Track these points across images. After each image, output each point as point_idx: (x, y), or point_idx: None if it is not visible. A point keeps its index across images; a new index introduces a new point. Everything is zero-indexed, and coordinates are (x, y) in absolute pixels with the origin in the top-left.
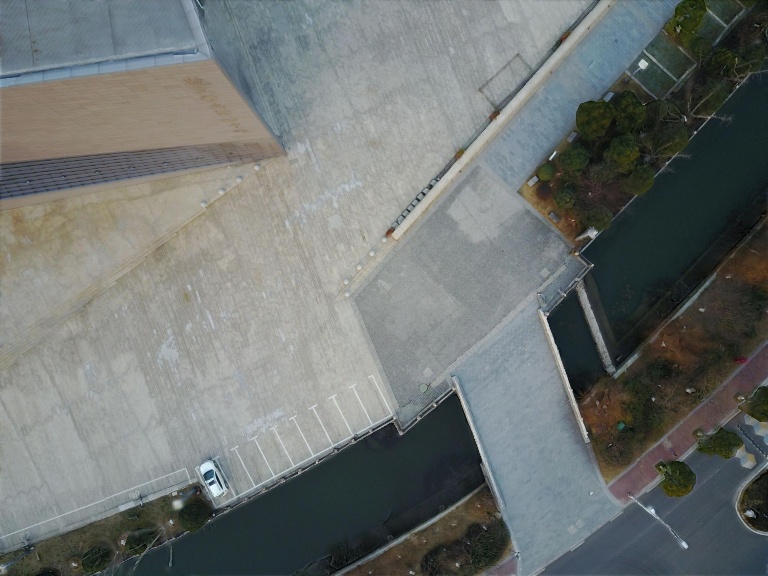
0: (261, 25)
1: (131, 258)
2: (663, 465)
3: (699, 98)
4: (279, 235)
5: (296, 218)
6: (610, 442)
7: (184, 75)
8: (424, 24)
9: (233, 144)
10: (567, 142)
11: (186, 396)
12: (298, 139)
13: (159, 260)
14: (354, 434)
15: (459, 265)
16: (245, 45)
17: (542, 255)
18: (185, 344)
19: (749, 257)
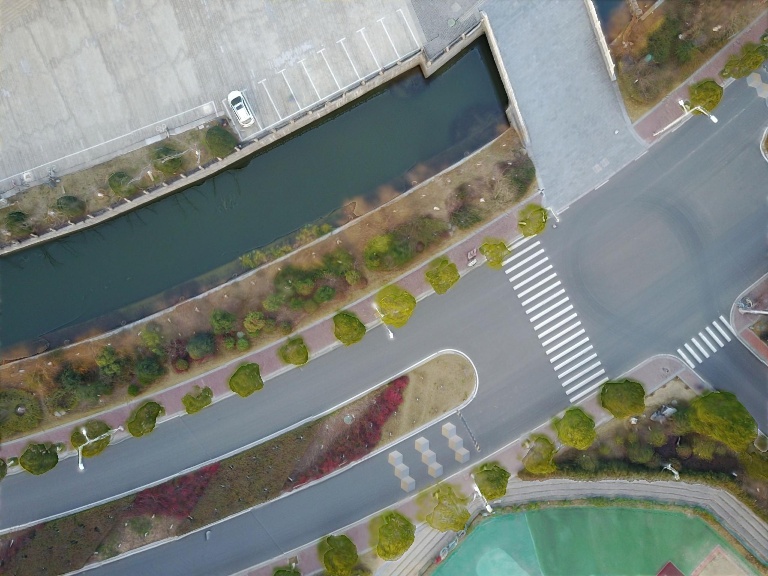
0: None
1: None
2: (688, 104)
3: None
4: None
5: None
6: (636, 77)
7: None
8: None
9: None
10: None
11: (215, 28)
12: None
13: None
14: (381, 68)
15: None
16: None
17: None
18: None
19: None
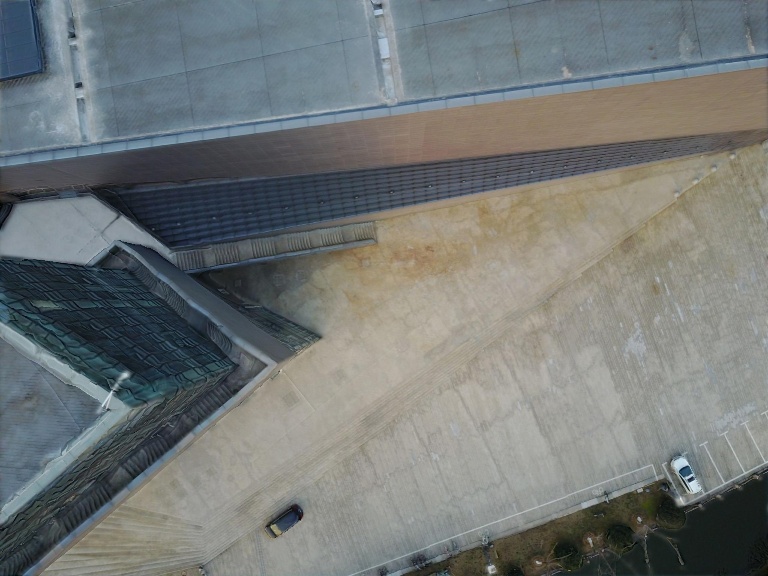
0: None
1: (600, 250)
2: None
3: None
4: (753, 226)
5: None
6: None
7: None
8: None
9: (753, 131)
10: None
11: (653, 391)
12: None
13: (626, 252)
14: None
15: None
16: None
17: None
18: (653, 337)
19: None
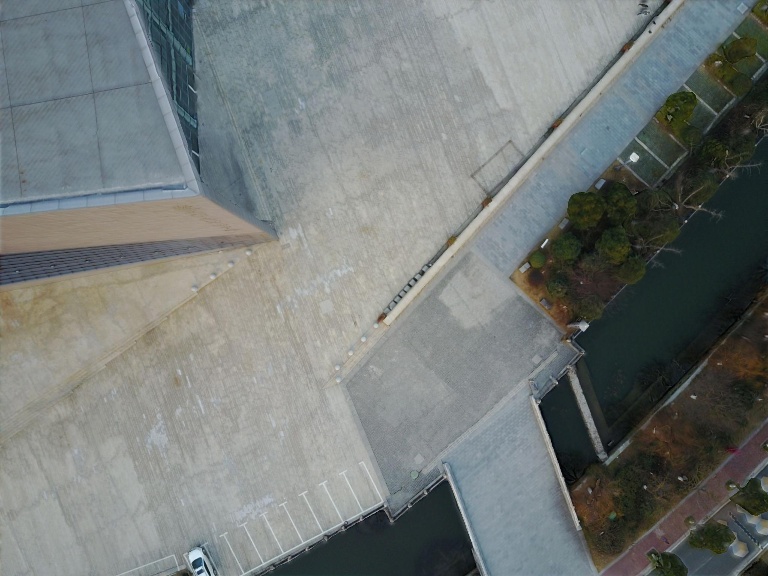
0: (254, 110)
1: (121, 342)
2: (655, 553)
3: (690, 189)
4: (270, 320)
5: (287, 303)
6: (602, 530)
7: (173, 204)
8: (417, 110)
9: (224, 236)
10: (559, 229)
11: (175, 482)
12: (290, 224)
13: (149, 344)
14: (344, 521)
15: (451, 351)
16: (238, 130)
17: (534, 341)
18: (174, 429)
19: (740, 344)
